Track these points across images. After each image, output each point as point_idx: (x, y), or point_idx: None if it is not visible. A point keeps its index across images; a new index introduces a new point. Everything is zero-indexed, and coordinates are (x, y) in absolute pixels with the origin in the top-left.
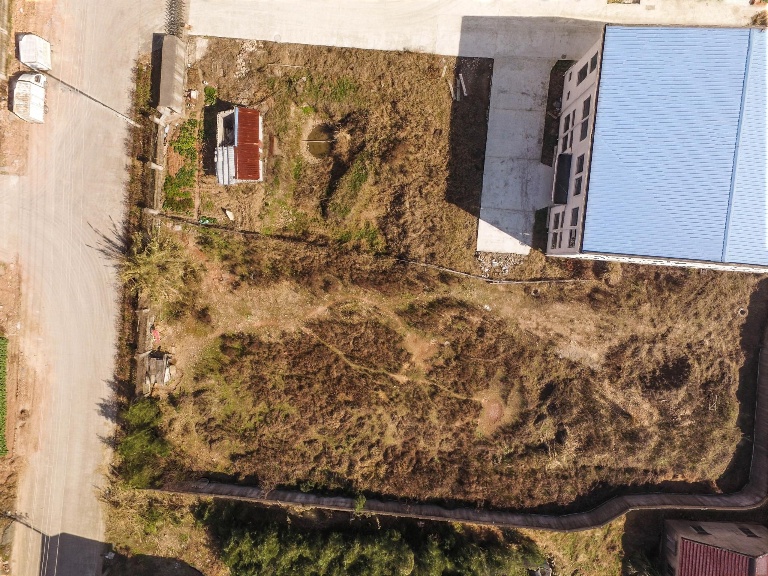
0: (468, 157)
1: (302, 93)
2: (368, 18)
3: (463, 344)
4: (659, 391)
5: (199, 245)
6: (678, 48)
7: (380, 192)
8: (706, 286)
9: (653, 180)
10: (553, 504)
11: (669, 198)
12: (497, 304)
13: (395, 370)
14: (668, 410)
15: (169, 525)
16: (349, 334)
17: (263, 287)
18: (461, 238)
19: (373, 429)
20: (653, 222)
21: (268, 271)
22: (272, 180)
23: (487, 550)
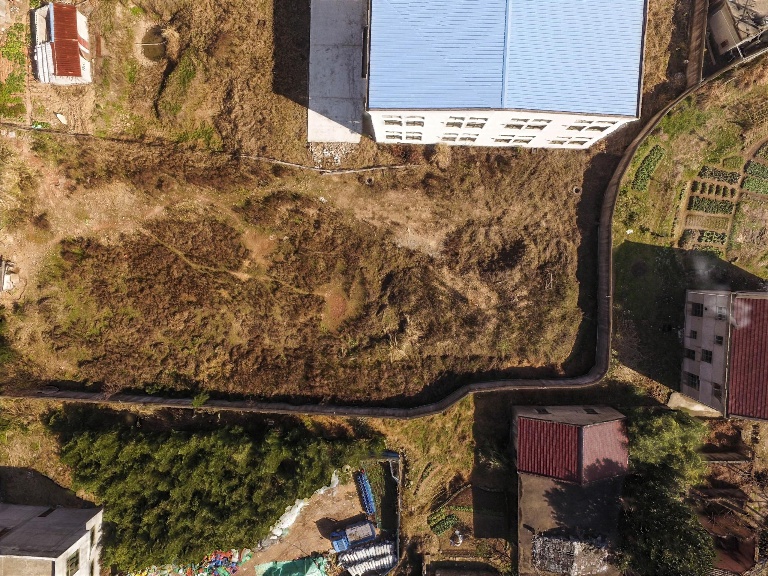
0: (293, 47)
1: None
2: None
3: (301, 238)
4: (494, 273)
5: (34, 151)
6: None
7: (213, 90)
8: (538, 165)
9: (431, 30)
10: (401, 396)
11: (447, 47)
12: (332, 195)
13: (235, 268)
14: (506, 292)
15: (19, 435)
16: (187, 233)
17: (99, 190)
18: (292, 130)
19: (217, 329)
20: (433, 73)
21: (103, 174)
22: (101, 81)
23: (331, 442)
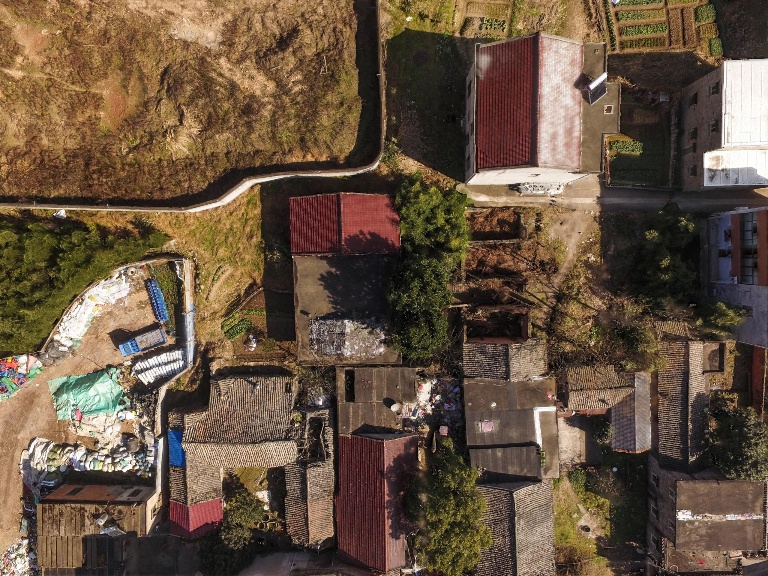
0: None
1: None
2: None
3: (75, 31)
4: (268, 57)
5: None
6: None
7: None
8: None
9: None
10: (185, 195)
11: None
12: None
13: (7, 64)
14: (282, 80)
15: None
16: None
17: None
18: None
19: None
20: None
21: None
22: None
23: None
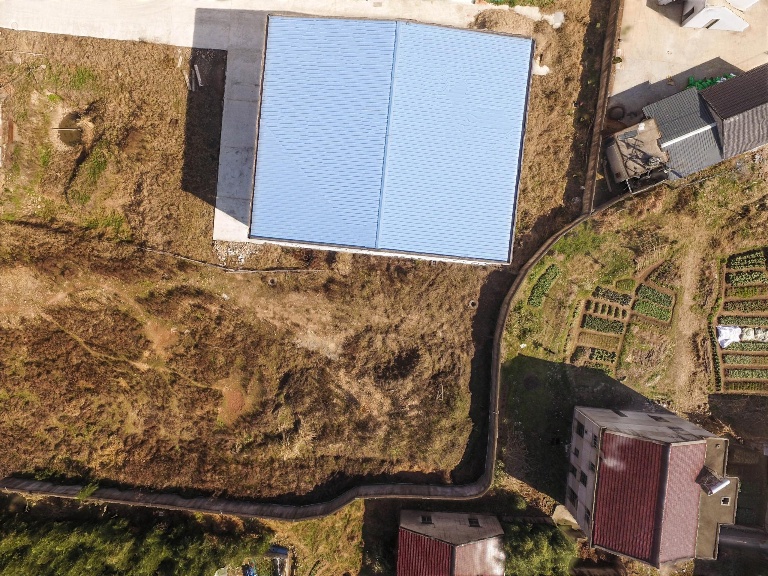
0: (204, 147)
1: (42, 80)
2: (103, 8)
3: (202, 332)
4: (387, 381)
5: None
6: (333, 39)
7: (125, 180)
8: (437, 278)
9: (312, 167)
10: (292, 494)
11: (327, 185)
12: (235, 293)
13: (135, 358)
14: (399, 400)
15: None
16: (88, 321)
17: (2, 273)
18: (198, 227)
19: (113, 417)
20: (313, 208)
21: (8, 257)
22: (11, 166)
23: (217, 539)
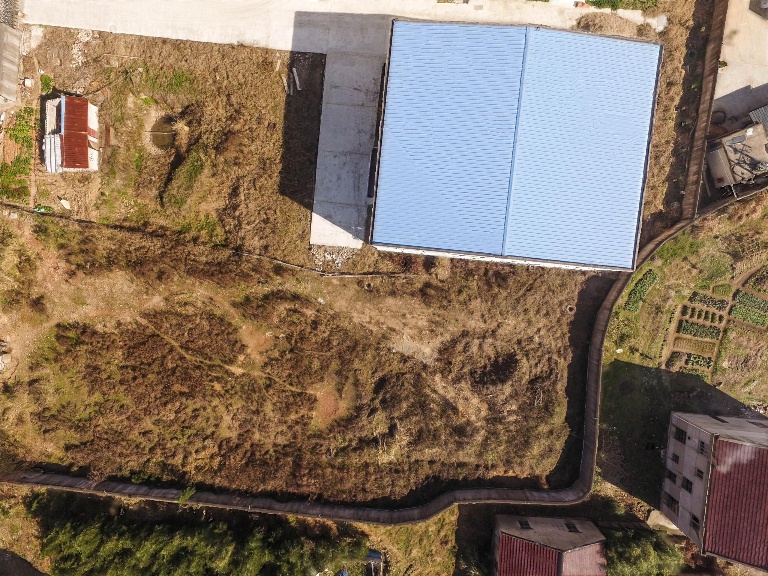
0: (301, 151)
1: (139, 84)
2: (202, 11)
3: (298, 337)
4: (486, 386)
5: (35, 233)
6: (460, 44)
7: (219, 184)
8: (534, 283)
9: (437, 173)
10: (387, 498)
11: (452, 191)
12: (331, 297)
13: (230, 362)
14: (496, 405)
15: (0, 516)
16: (183, 325)
17: (98, 276)
18: (295, 231)
19: (208, 421)
20: (438, 215)
21: (104, 261)
22: (108, 170)
23: (314, 543)
